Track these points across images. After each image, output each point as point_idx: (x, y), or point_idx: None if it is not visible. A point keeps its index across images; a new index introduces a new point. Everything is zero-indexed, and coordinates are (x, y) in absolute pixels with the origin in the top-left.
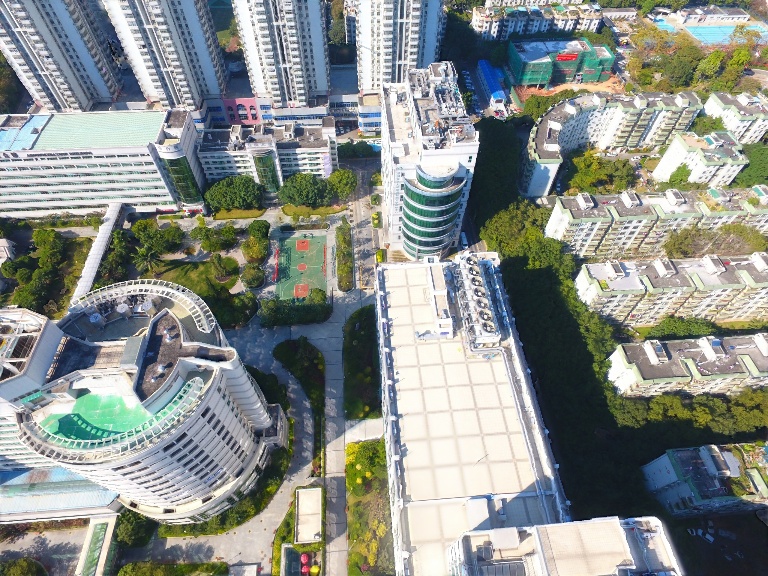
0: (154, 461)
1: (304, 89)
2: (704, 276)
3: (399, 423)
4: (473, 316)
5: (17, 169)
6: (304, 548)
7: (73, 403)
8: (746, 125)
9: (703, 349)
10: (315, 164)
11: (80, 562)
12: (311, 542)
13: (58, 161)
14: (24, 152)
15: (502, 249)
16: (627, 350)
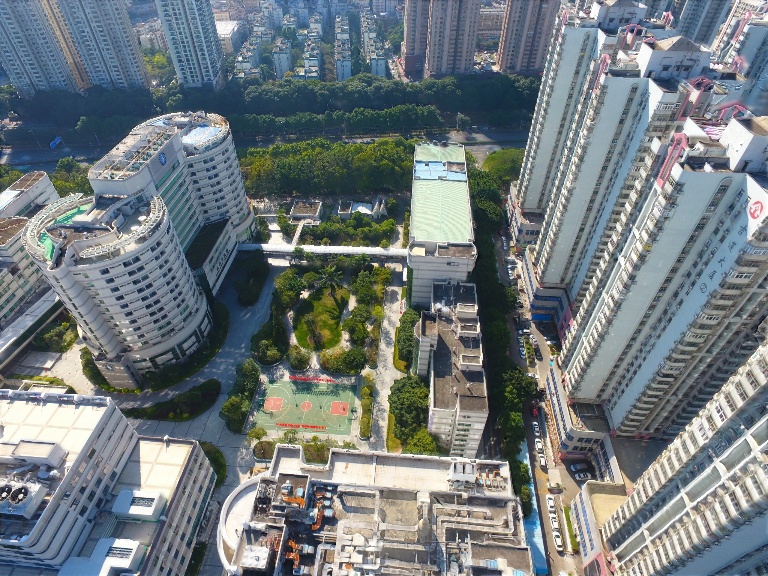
0: None
1: (577, 382)
2: None
3: None
4: None
5: None
6: None
7: None
8: None
9: None
10: None
11: None
12: None
13: None
14: None
15: None
16: None
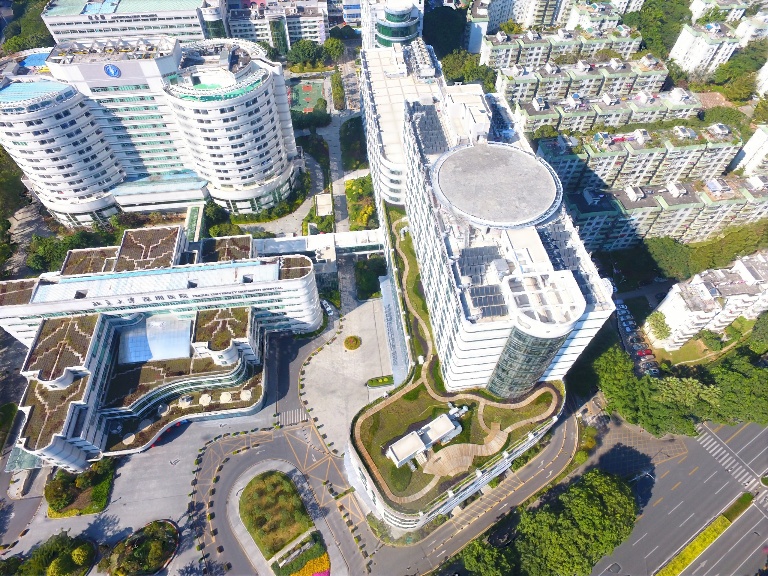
0: (240, 113)
1: None
2: (577, 73)
3: (376, 107)
4: (419, 62)
5: (102, 30)
6: (322, 224)
7: (192, 87)
8: (626, 1)
9: (569, 102)
10: (313, 32)
11: (186, 222)
12: (326, 215)
13: (132, 23)
14: (109, 15)
15: (448, 76)
16: (522, 106)
